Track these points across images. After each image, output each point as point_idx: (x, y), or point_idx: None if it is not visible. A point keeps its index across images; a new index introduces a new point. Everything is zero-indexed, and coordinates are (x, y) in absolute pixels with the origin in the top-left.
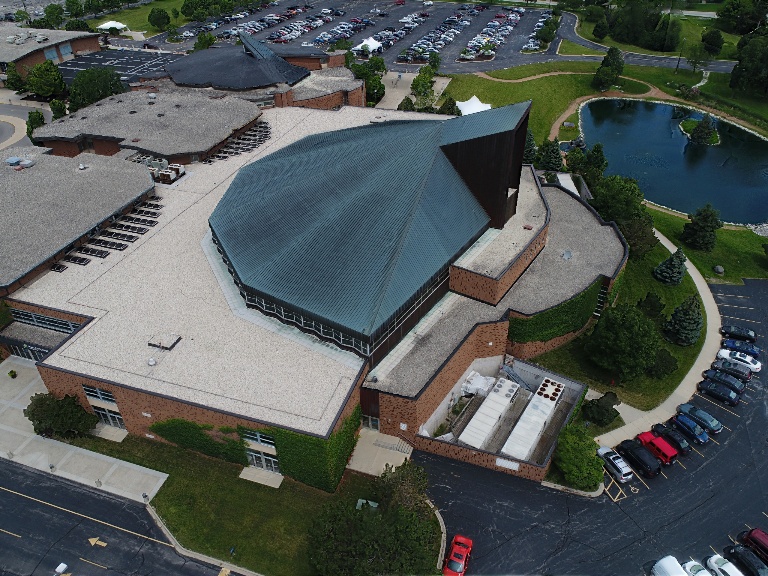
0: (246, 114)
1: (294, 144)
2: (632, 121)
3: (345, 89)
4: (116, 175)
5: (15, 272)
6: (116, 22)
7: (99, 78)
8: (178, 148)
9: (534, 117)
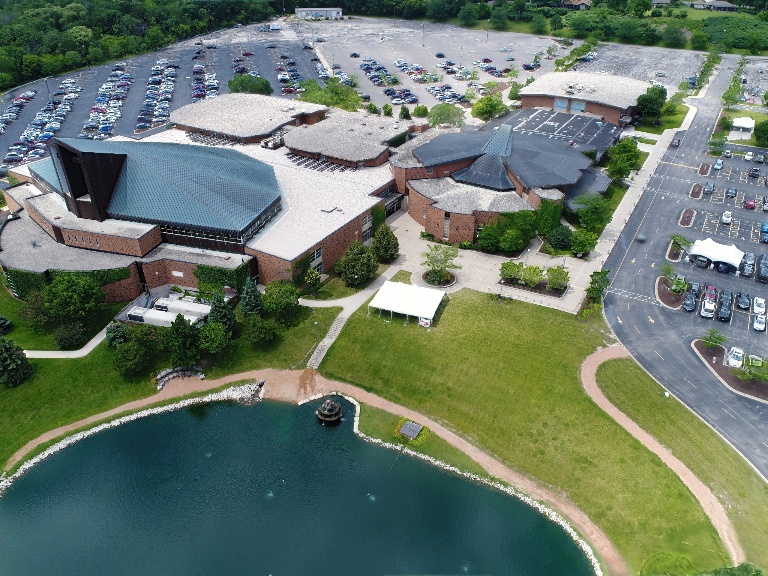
0: (350, 155)
1: (252, 159)
2: (445, 569)
3: (440, 204)
4: (258, 127)
5: (177, 121)
6: (748, 119)
7: (436, 110)
8: (291, 138)
9: (431, 384)
